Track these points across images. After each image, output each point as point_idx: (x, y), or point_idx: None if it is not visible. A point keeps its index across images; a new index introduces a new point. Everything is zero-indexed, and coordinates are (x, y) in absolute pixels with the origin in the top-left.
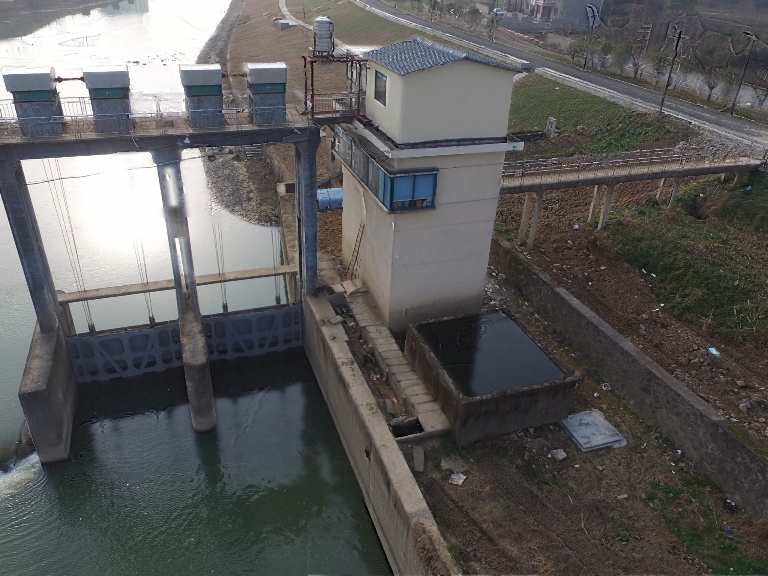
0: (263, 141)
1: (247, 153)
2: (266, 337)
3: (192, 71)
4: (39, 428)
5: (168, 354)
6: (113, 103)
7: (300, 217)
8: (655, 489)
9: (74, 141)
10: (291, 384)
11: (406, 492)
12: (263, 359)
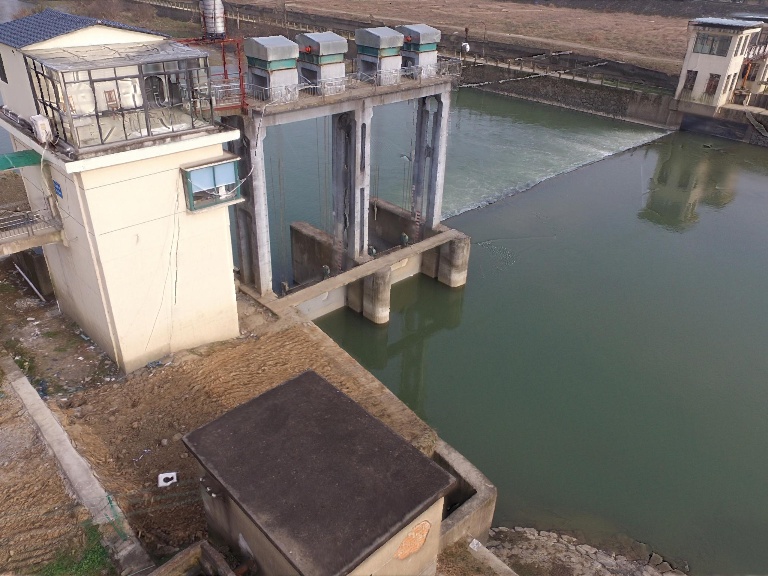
0: None
1: None
2: None
3: None
4: None
5: None
6: None
7: None
8: None
9: None
10: None
11: None
12: None
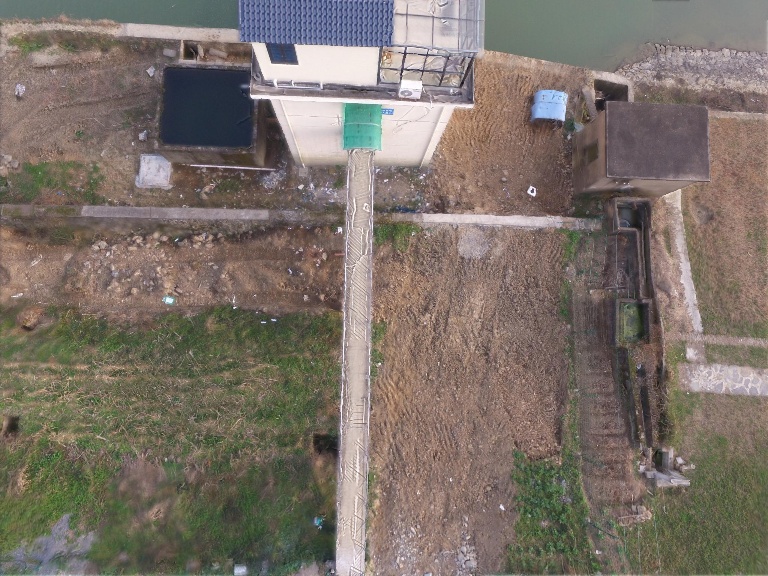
0: None
1: None
2: None
3: None
4: None
5: None
6: None
7: None
8: (99, 175)
9: None
10: None
11: (141, 29)
12: None
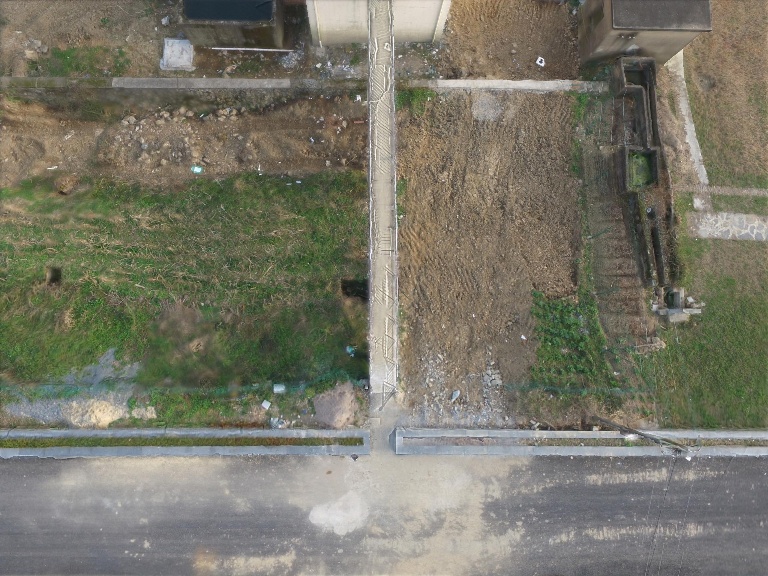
0: None
1: None
2: None
3: None
4: None
5: None
6: None
7: None
8: (125, 59)
9: None
10: None
11: None
12: None
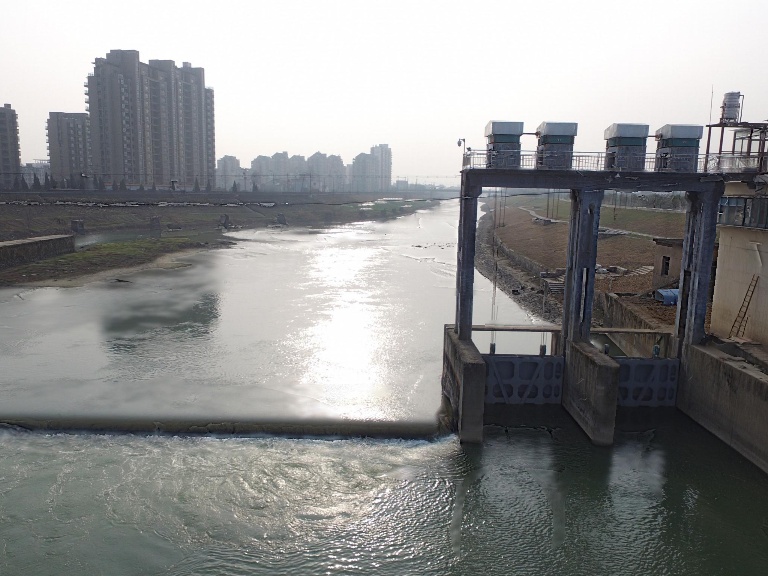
0: (673, 187)
1: (551, 288)
2: (641, 388)
3: (626, 125)
4: (470, 402)
5: (548, 389)
6: (562, 147)
7: (688, 269)
8: None
9: (533, 170)
10: (679, 428)
11: None
12: (635, 412)
